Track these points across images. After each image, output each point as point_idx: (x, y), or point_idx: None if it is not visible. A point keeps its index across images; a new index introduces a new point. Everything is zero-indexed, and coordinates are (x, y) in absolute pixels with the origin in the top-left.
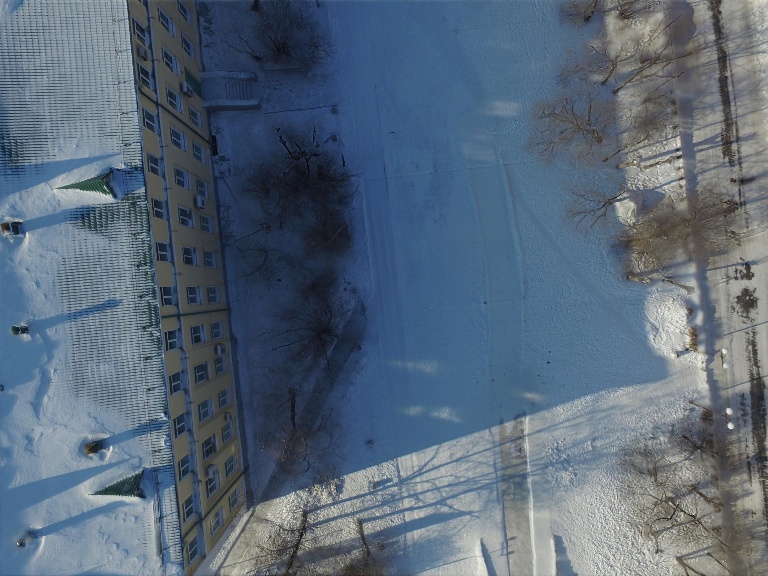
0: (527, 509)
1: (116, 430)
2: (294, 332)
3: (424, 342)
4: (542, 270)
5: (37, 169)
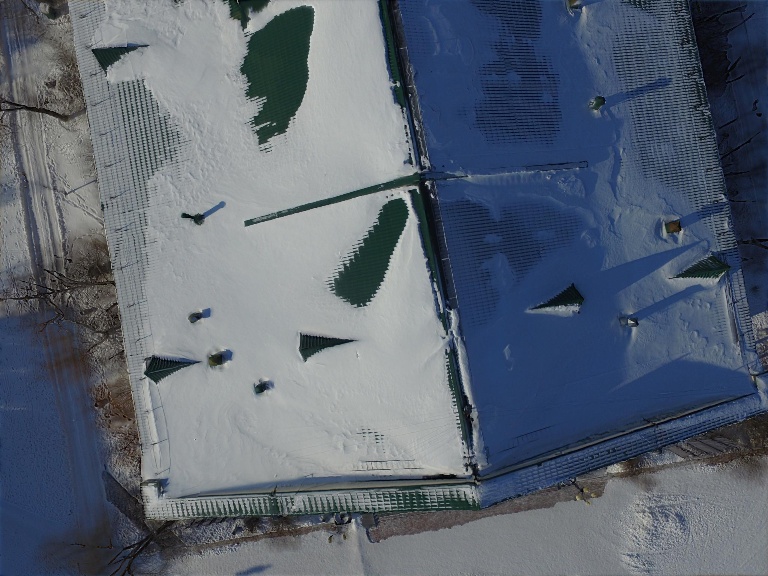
0: None
1: (683, 212)
2: None
3: None
4: None
5: None
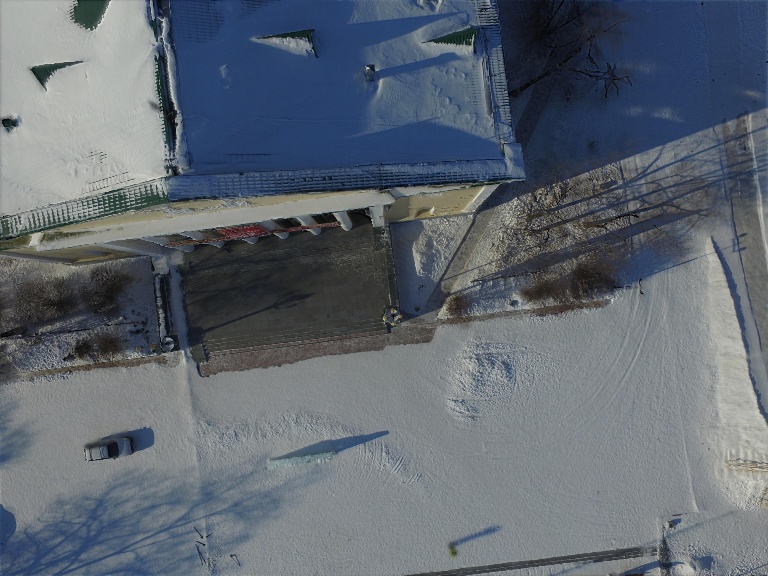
0: (755, 206)
1: None
2: (511, 36)
3: (642, 45)
4: None
5: None
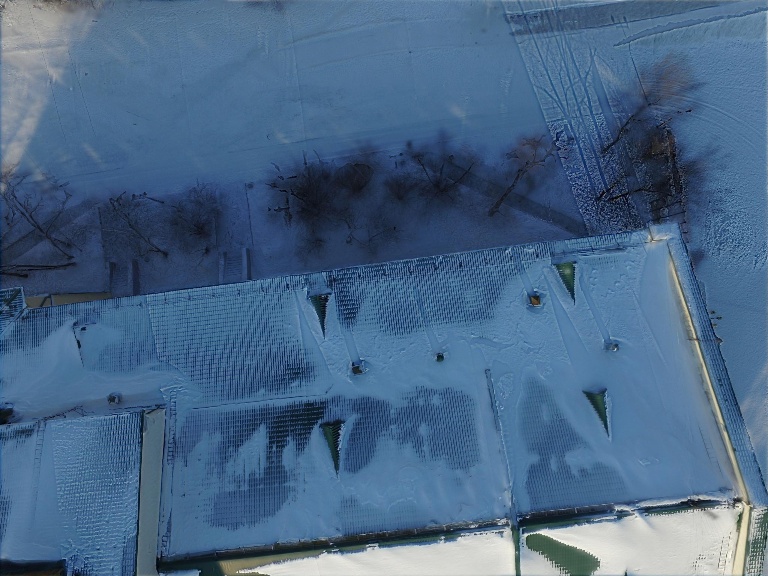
0: (586, 8)
1: (520, 287)
2: None
3: (445, 103)
4: (381, 7)
5: (309, 353)
